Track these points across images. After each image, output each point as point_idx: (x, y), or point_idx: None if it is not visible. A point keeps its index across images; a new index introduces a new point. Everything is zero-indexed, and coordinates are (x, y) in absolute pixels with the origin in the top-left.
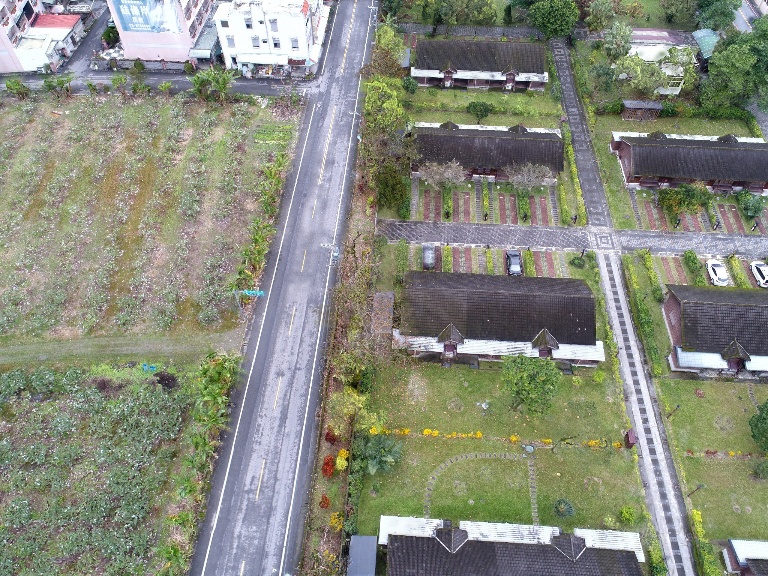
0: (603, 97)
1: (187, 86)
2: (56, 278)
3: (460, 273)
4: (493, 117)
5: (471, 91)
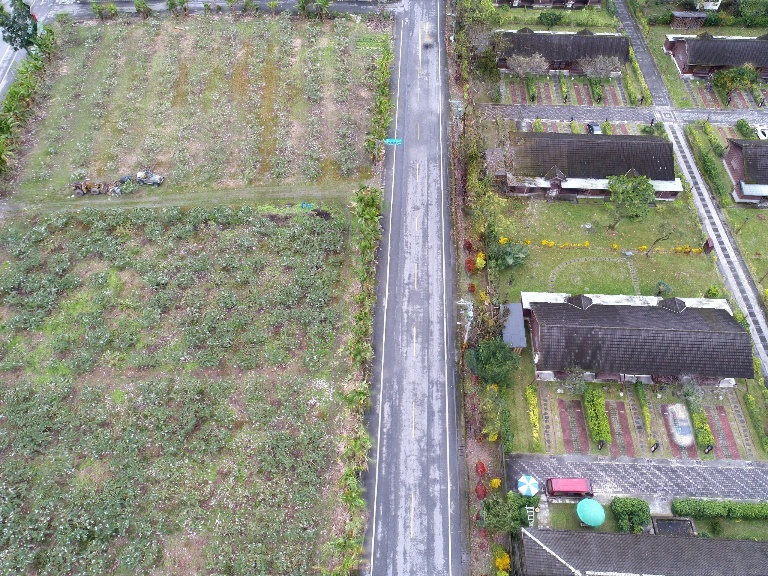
0: (652, 12)
1: (288, 7)
2: (214, 144)
3: (555, 133)
4: (559, 28)
5: (537, 9)
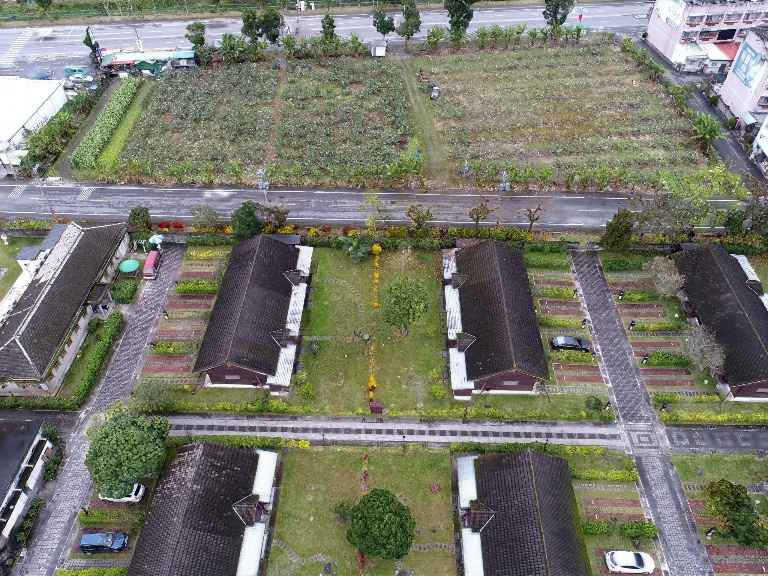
0: None
1: None
2: None
3: (529, 285)
4: None
5: None
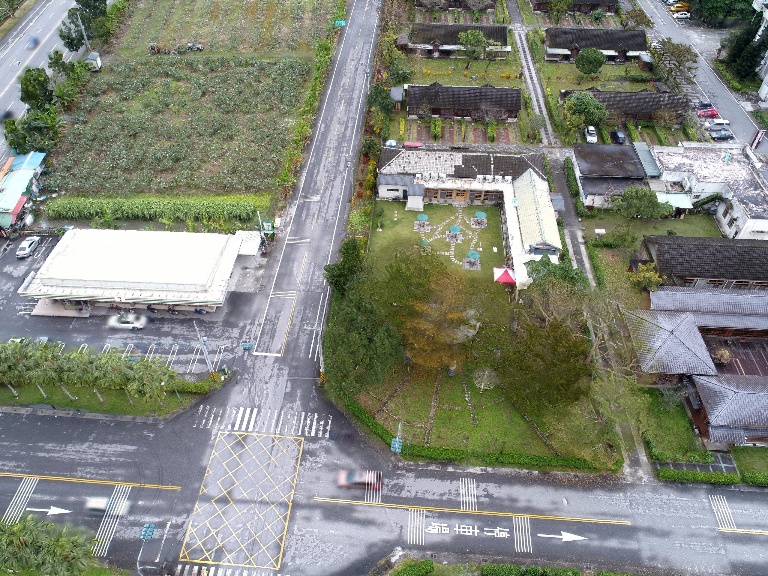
0: None
1: None
2: None
3: None
4: None
5: None
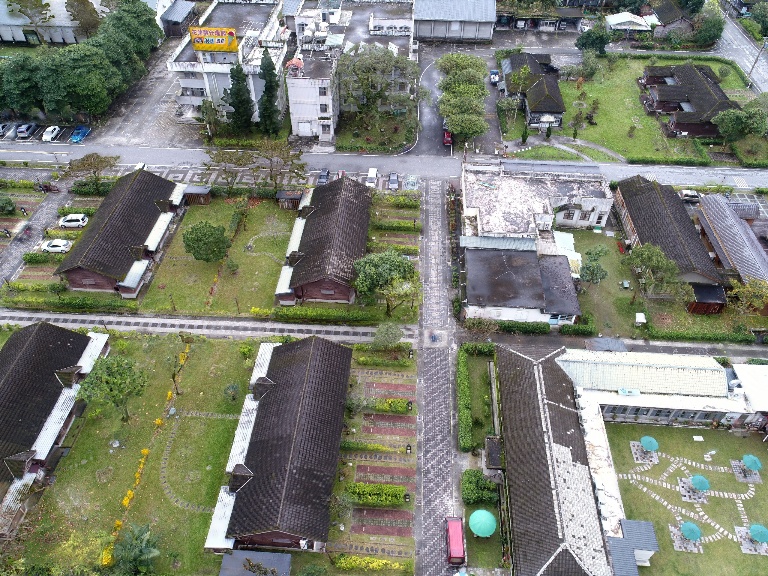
0: None
1: None
2: None
3: None
4: None
5: None
